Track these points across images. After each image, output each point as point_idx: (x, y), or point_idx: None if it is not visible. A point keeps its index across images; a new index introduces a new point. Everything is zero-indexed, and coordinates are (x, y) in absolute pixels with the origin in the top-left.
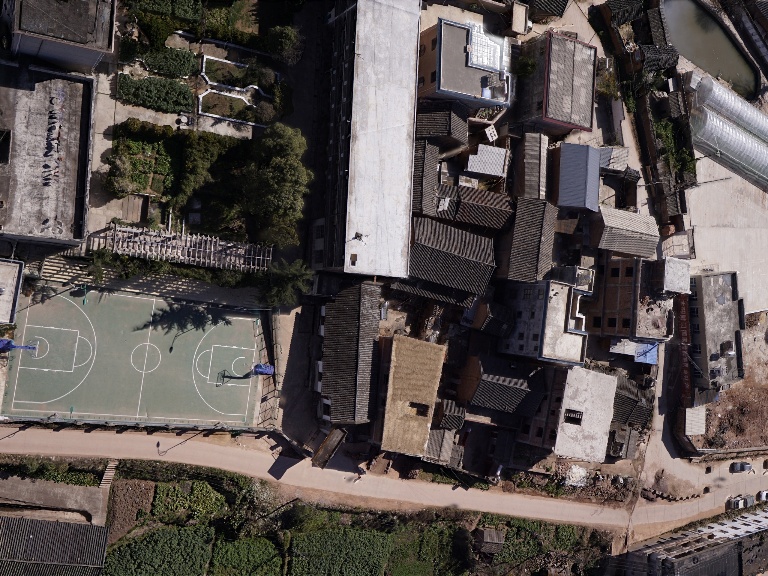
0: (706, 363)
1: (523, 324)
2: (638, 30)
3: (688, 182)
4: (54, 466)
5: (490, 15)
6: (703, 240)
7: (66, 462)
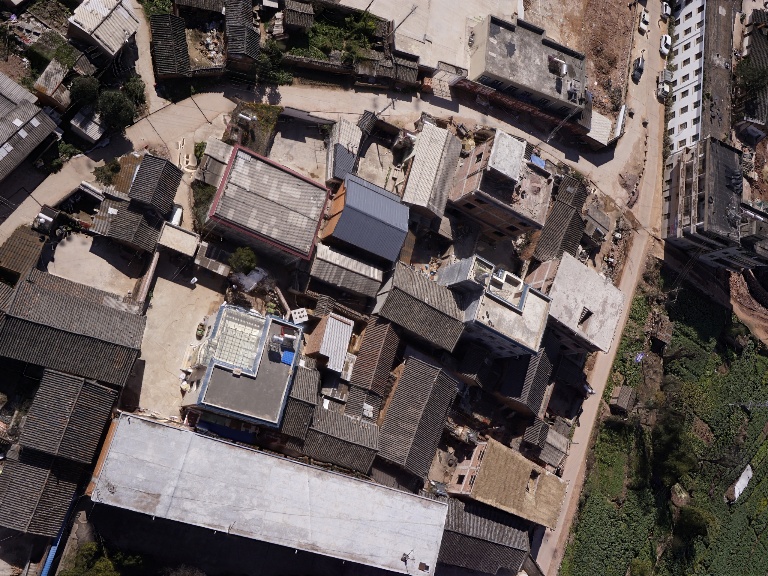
0: (562, 102)
1: (492, 343)
2: (191, 19)
3: (385, 34)
4: None
5: (158, 266)
6: (440, 29)
7: None
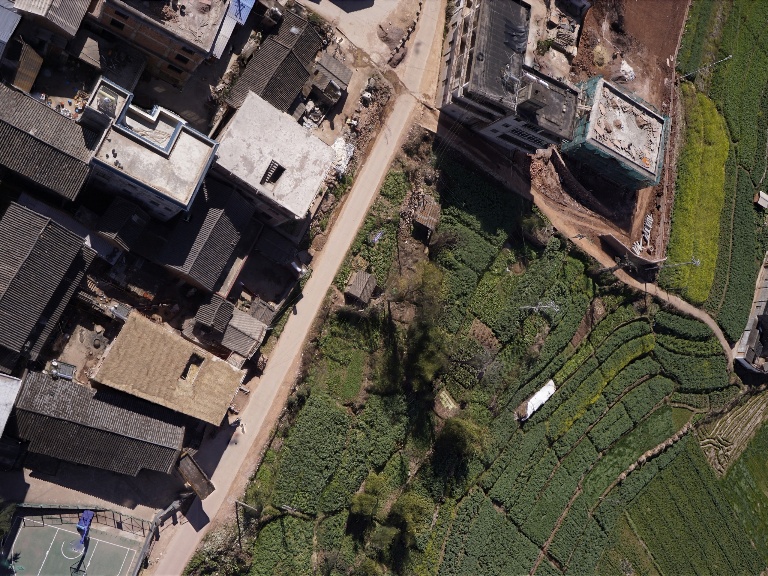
0: None
1: (140, 196)
2: None
3: None
4: None
5: None
6: None
7: None
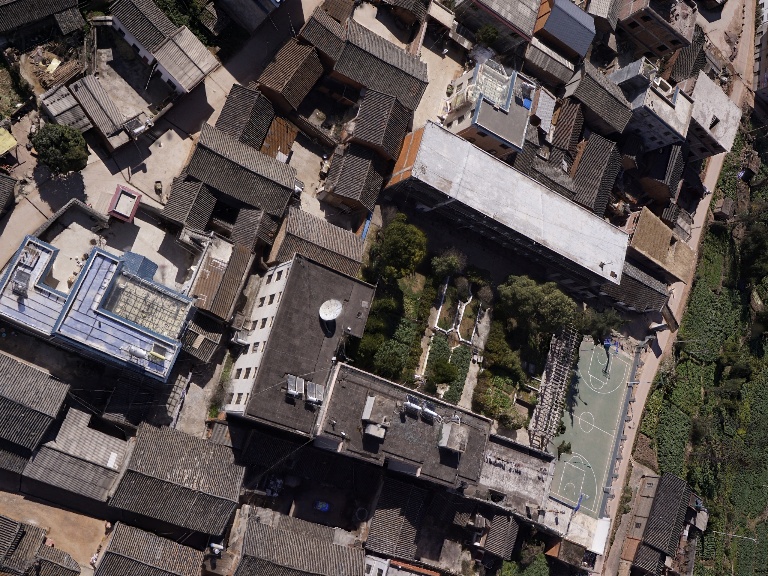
0: None
1: (647, 133)
2: None
3: None
4: (629, 495)
5: None
6: None
7: (626, 487)
